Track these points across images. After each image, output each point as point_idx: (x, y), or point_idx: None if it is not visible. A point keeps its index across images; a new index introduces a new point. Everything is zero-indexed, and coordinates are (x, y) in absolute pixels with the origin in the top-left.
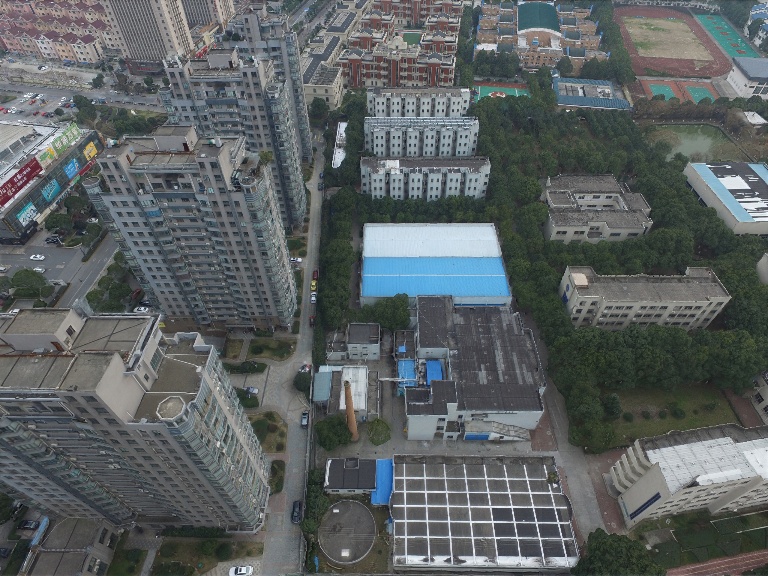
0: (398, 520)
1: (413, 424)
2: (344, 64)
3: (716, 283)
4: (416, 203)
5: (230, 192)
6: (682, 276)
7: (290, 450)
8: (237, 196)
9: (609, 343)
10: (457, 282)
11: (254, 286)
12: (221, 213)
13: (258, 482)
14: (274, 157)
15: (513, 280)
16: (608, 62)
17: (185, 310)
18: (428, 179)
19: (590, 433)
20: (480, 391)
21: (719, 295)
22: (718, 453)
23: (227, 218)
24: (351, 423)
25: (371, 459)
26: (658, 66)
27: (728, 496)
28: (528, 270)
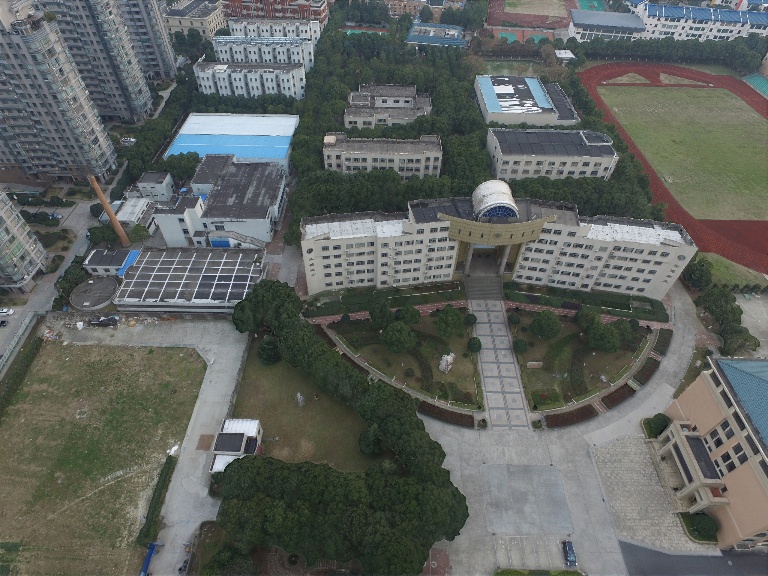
0: (128, 280)
1: (162, 226)
2: (227, 5)
3: (438, 145)
4: (237, 98)
5: (10, 34)
6: (414, 140)
7: (72, 251)
8: (16, 38)
9: (334, 179)
10: (247, 150)
11: (58, 132)
12: (9, 55)
13: (22, 250)
14: (102, 46)
15: (294, 150)
16: (462, 11)
17: (10, 157)
18: (247, 78)
19: (293, 231)
20: (224, 208)
21: (434, 151)
22: (358, 226)
23: (15, 60)
24: (114, 224)
25: (126, 250)
26: (515, 19)
27: (376, 266)
28: (307, 142)
